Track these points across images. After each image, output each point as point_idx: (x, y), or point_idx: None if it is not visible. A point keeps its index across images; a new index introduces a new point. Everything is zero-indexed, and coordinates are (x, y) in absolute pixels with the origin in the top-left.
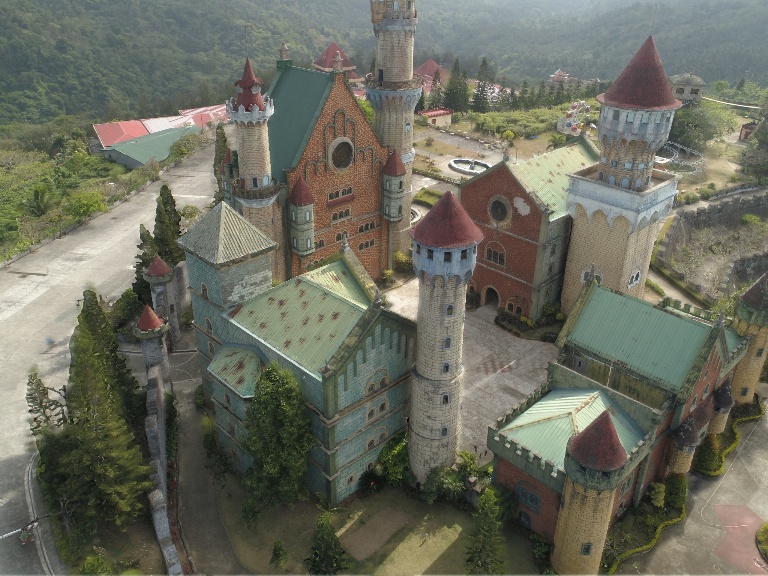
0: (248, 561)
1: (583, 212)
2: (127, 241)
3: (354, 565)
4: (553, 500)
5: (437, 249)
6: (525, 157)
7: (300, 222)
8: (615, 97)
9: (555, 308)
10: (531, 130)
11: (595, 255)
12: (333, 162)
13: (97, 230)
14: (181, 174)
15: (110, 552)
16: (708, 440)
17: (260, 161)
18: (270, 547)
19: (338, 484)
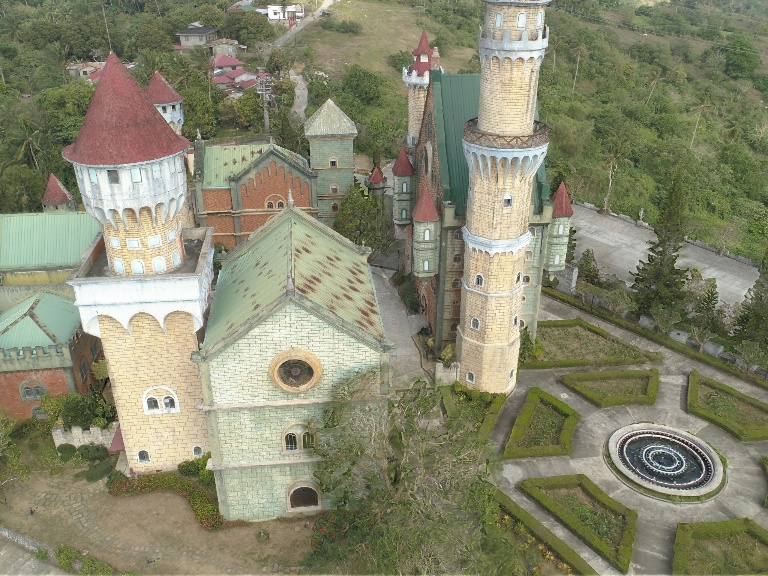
0: None
1: None
2: (734, 296)
3: None
4: None
5: None
6: None
7: None
8: None
9: None
10: None
11: None
12: None
13: None
14: None
15: None
16: None
17: None
18: None
19: None
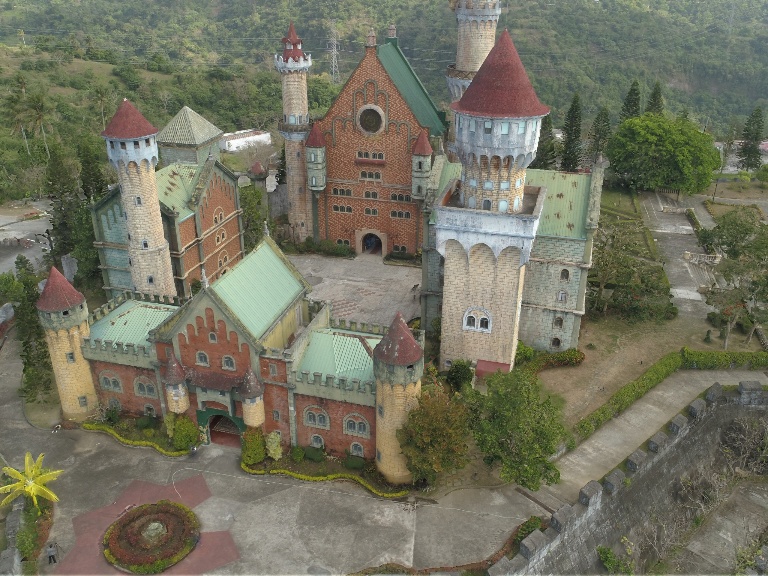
0: None
1: None
2: None
3: None
4: None
5: None
6: None
7: (307, 160)
8: None
9: None
10: None
11: None
12: (361, 124)
13: None
14: None
15: None
16: None
17: (288, 102)
18: None
19: None
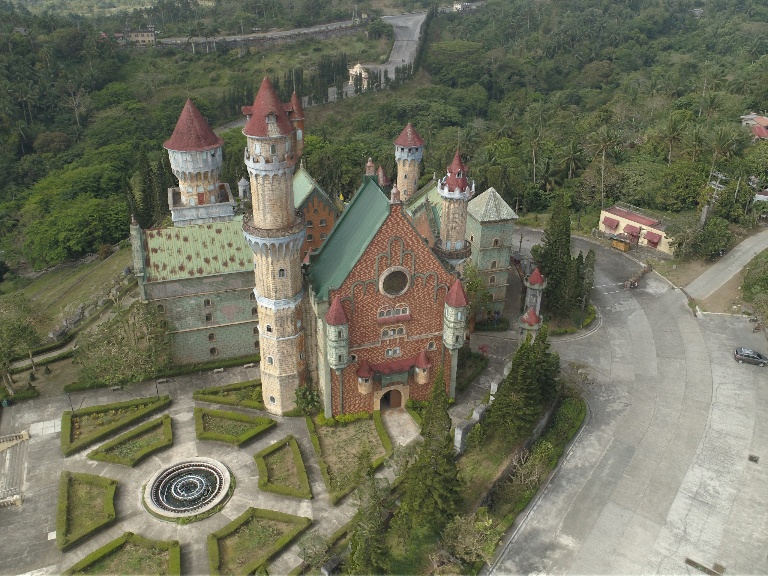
0: None
1: None
2: None
3: None
4: None
5: None
6: None
7: None
8: None
9: None
10: None
11: None
12: None
13: None
14: None
15: None
16: None
17: None
18: None
19: None
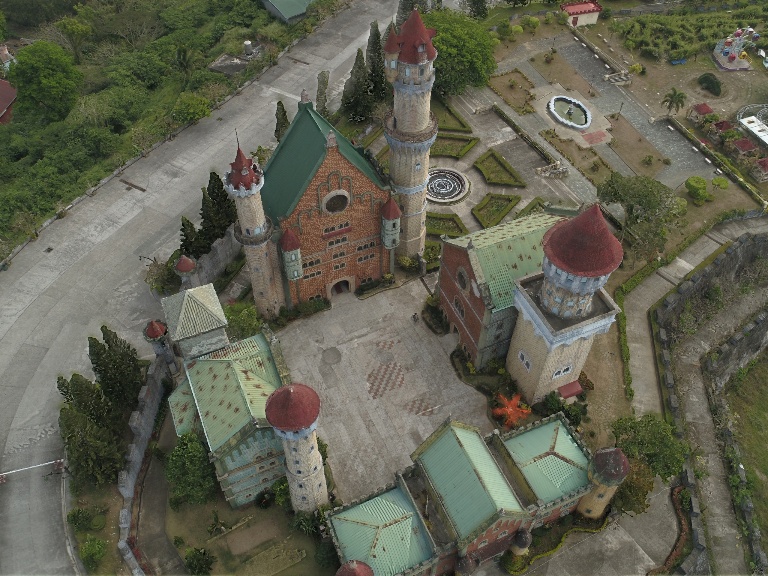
0: (170, 530)
1: None
2: (218, 157)
3: (228, 557)
4: None
5: (274, 427)
6: (645, 97)
7: (287, 261)
8: (553, 246)
9: (498, 364)
10: (676, 54)
11: (528, 347)
12: (327, 209)
13: (201, 134)
14: (299, 58)
15: (98, 494)
16: (511, 554)
17: (251, 219)
18: (187, 524)
19: (238, 498)
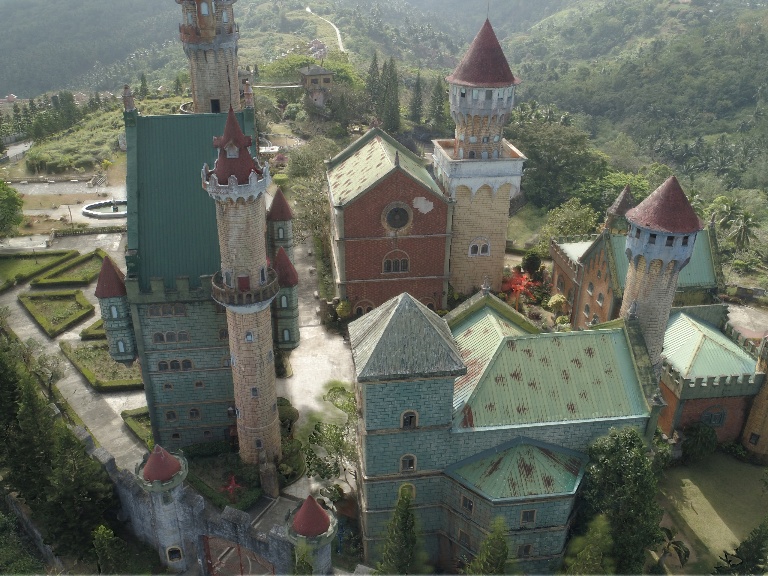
0: None
1: (464, 192)
2: None
3: (703, 567)
4: (740, 405)
5: None
6: None
7: (295, 306)
8: (482, 79)
9: None
10: (105, 155)
11: (480, 227)
12: None
13: None
14: None
15: None
16: None
17: None
18: None
19: None
